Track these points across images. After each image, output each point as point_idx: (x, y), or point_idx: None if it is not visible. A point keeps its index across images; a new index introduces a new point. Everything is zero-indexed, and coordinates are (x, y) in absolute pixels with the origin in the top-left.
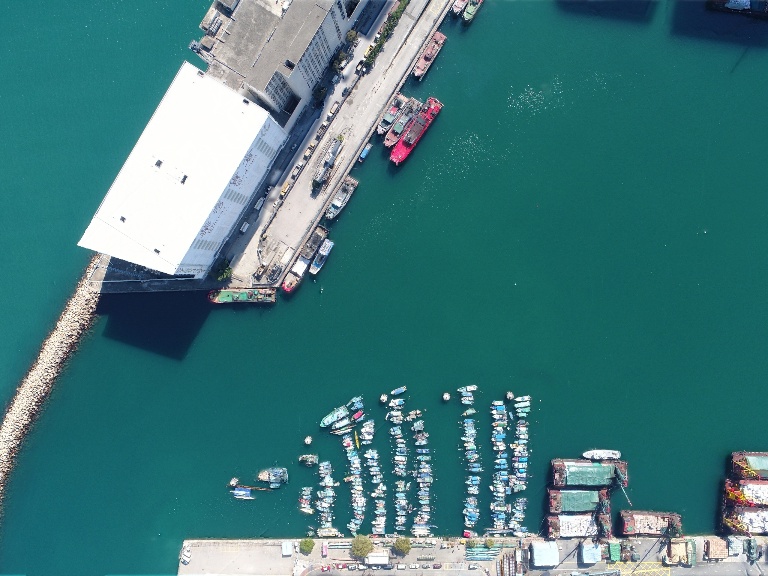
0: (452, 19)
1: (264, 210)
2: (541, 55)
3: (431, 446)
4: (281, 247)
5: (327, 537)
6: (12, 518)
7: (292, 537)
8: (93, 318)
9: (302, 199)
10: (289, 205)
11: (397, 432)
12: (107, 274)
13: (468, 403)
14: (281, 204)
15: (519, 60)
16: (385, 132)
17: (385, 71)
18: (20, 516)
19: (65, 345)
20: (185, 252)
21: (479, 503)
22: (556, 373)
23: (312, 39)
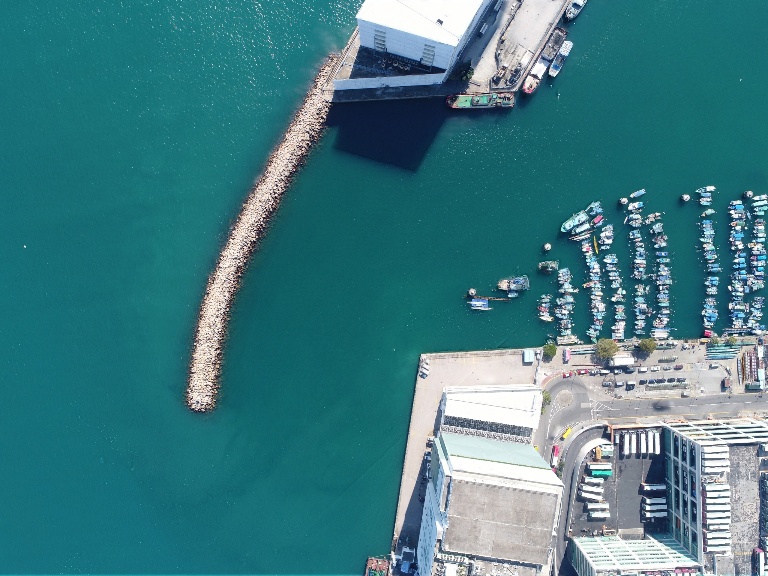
0: None
1: (502, 13)
2: None
3: (669, 249)
4: (519, 50)
5: (566, 345)
6: (237, 342)
7: (531, 346)
8: (322, 130)
9: (540, 1)
10: (527, 7)
11: (637, 235)
12: (353, 72)
13: (706, 204)
14: (519, 6)
15: None
16: None
17: None
18: (245, 339)
19: (295, 157)
20: (468, 23)
21: (717, 304)
22: None
23: None
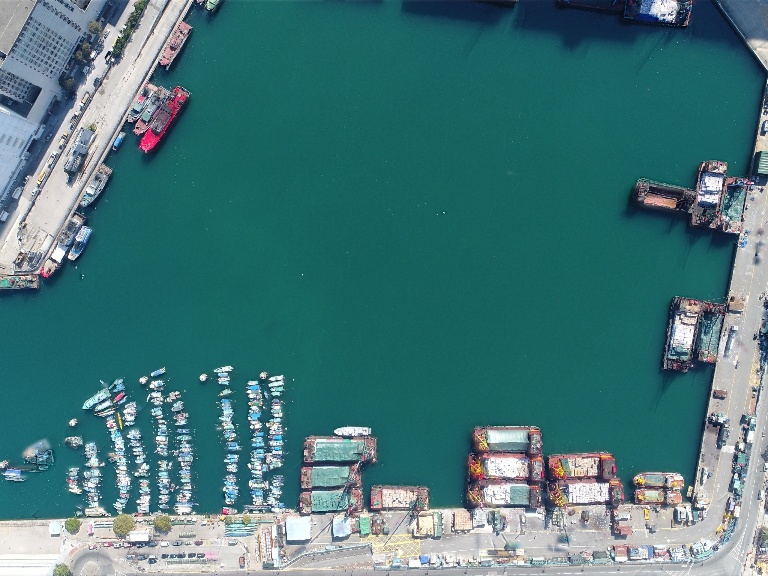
0: (198, 9)
1: (23, 199)
2: (284, 43)
3: (191, 426)
4: (41, 235)
5: (95, 516)
6: None
7: (61, 517)
8: None
9: (59, 187)
10: (47, 194)
11: (157, 413)
12: None
13: (225, 383)
14: (39, 193)
15: (263, 48)
16: (135, 121)
17: (134, 61)
18: None
19: None
20: None
21: (238, 481)
22: (308, 353)
23: (22, 30)
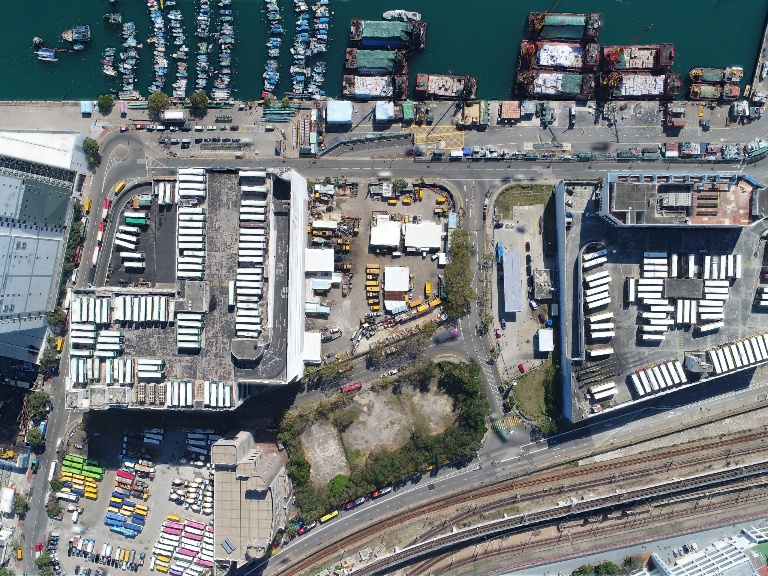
0: None
1: None
2: None
3: (235, 8)
4: None
5: None
6: None
7: (93, 99)
8: None
9: None
10: None
11: None
12: None
13: None
14: None
15: None
16: None
17: None
18: None
19: None
20: None
21: (279, 67)
22: None
23: None
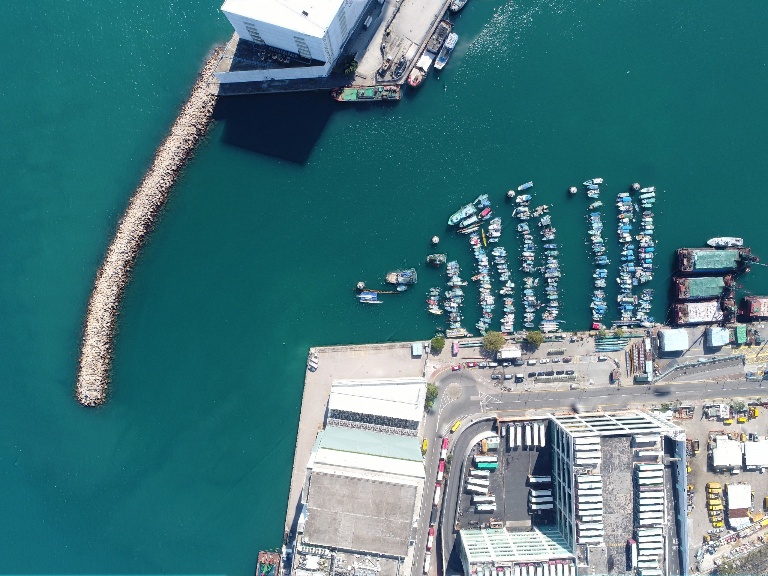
0: None
1: (387, 5)
2: None
3: (558, 241)
4: (405, 43)
5: (455, 338)
6: (127, 336)
7: (421, 339)
8: (209, 123)
9: None
10: None
11: (525, 227)
12: (233, 65)
13: (594, 196)
14: None
15: None
16: None
17: None
18: (135, 334)
19: (181, 151)
20: (334, 14)
21: (606, 296)
22: (680, 163)
23: None
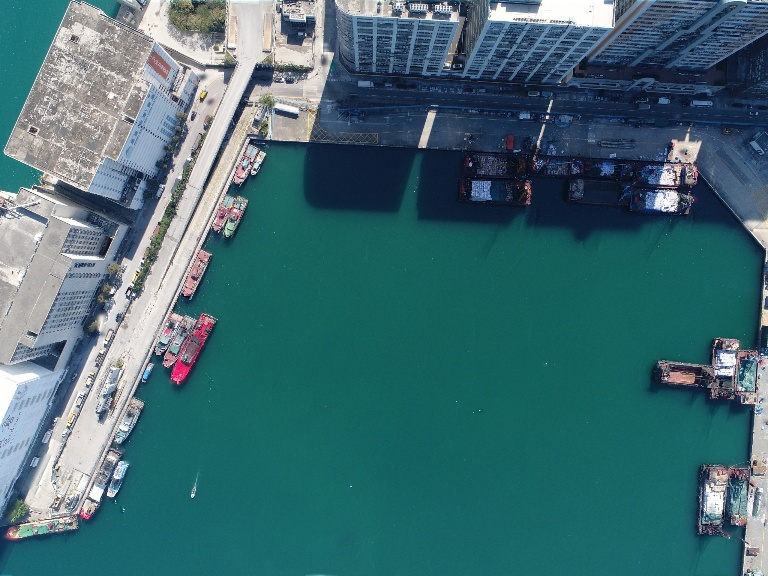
0: (215, 235)
1: (53, 441)
2: (306, 260)
3: None
4: (76, 475)
5: None
6: None
7: None
8: None
9: (90, 426)
10: (78, 433)
11: None
12: None
13: None
14: (70, 433)
15: (285, 267)
16: (163, 352)
17: (155, 293)
18: None
19: None
20: None
21: None
22: (360, 559)
23: (51, 307)
